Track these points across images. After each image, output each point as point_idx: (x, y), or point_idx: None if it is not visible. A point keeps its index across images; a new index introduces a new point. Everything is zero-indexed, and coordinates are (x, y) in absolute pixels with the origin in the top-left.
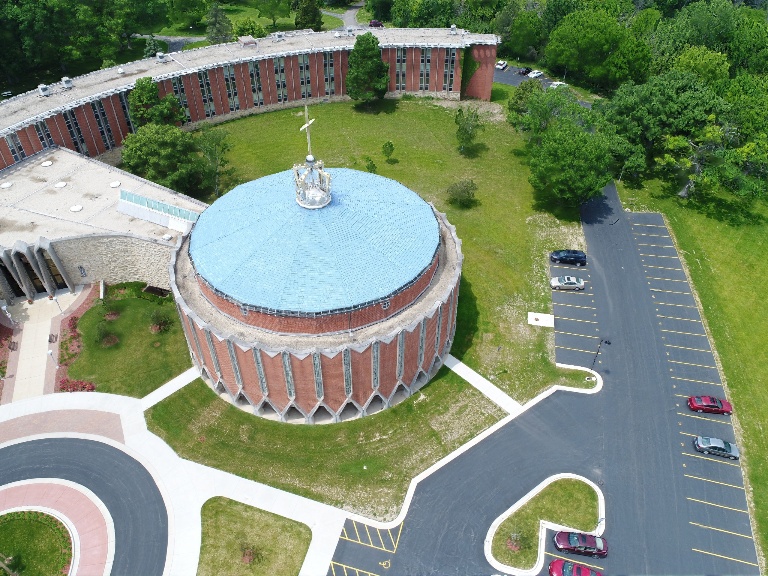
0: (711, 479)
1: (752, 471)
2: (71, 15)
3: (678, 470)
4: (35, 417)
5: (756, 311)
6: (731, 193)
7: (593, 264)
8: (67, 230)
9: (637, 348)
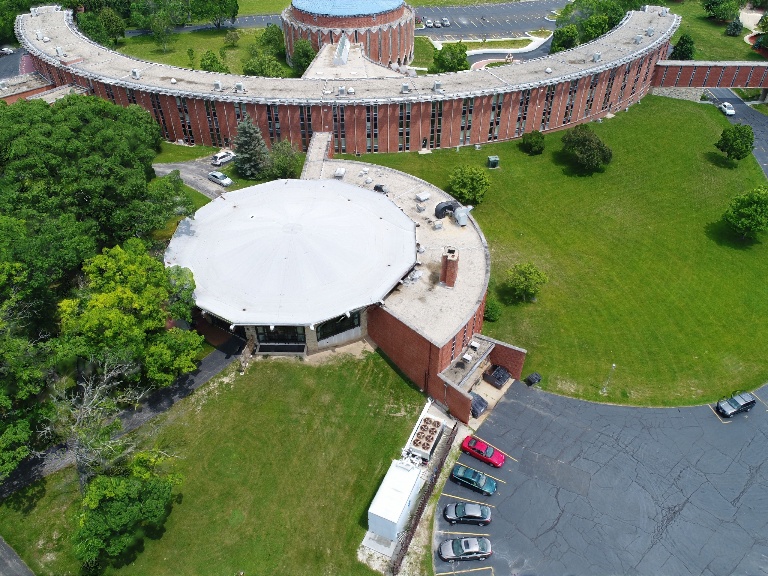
0: None
1: None
2: None
3: None
4: None
5: None
6: None
7: None
8: (374, 69)
9: None
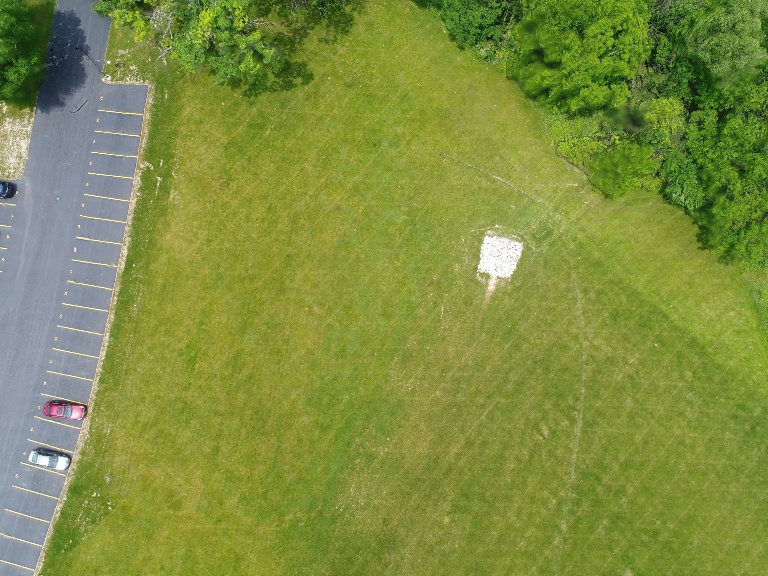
0: (33, 490)
1: (74, 481)
2: None
3: (9, 481)
4: None
5: (190, 265)
6: (283, 20)
7: (24, 194)
8: None
9: (26, 331)
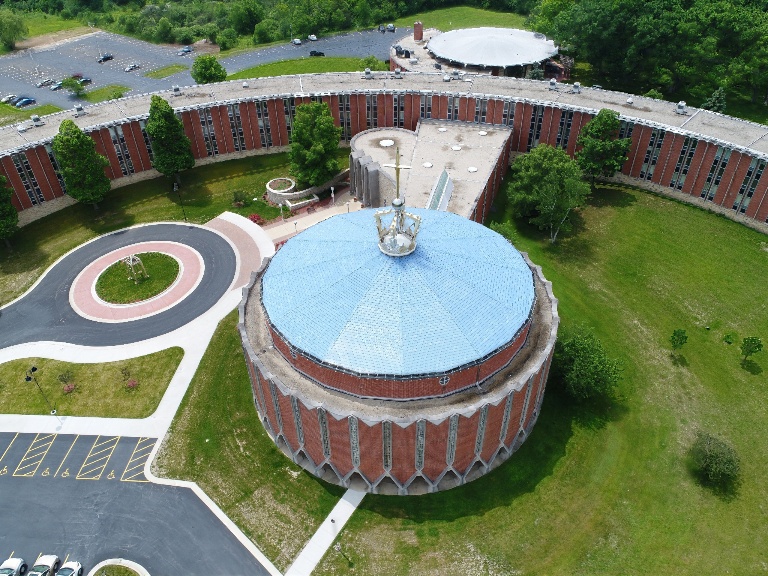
0: None
1: None
2: (692, 42)
3: None
4: (252, 244)
5: None
6: None
7: None
8: None
9: None
